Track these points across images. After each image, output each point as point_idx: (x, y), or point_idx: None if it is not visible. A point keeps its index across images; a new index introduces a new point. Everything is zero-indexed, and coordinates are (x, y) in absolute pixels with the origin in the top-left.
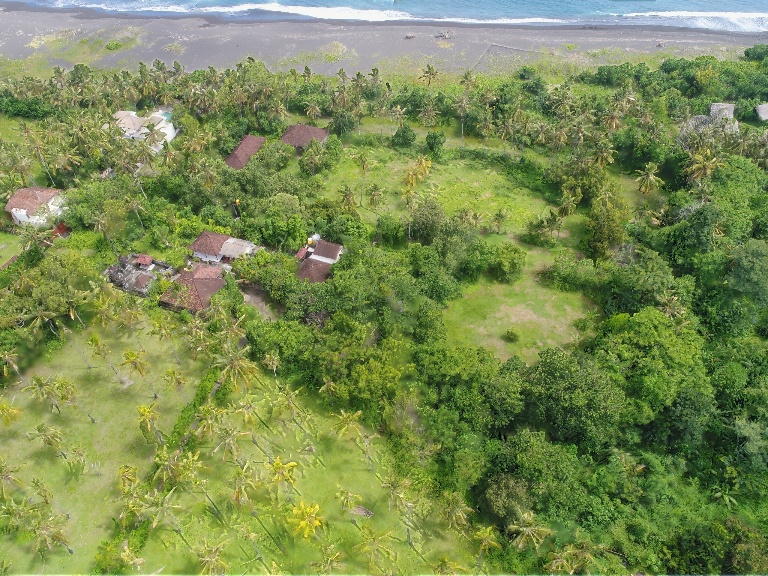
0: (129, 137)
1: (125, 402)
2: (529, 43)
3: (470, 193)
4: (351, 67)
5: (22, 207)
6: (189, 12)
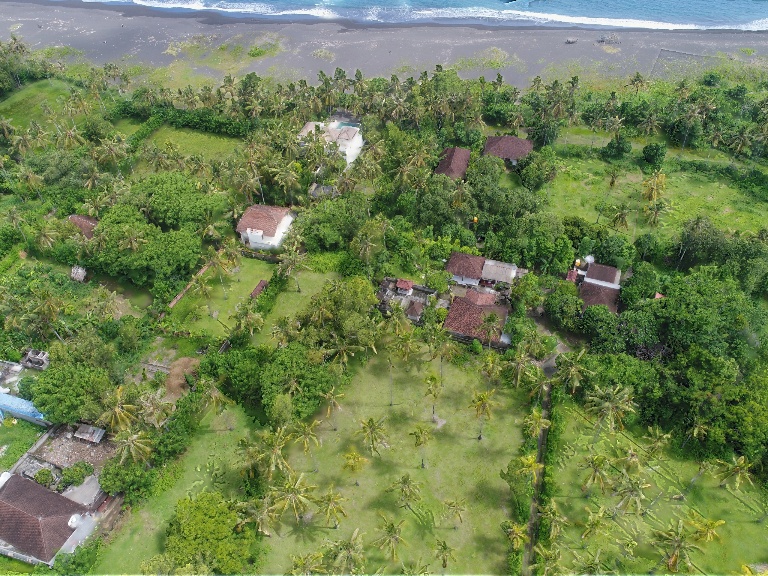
0: (328, 150)
1: (447, 444)
2: (701, 48)
3: (709, 208)
4: (520, 74)
5: (257, 227)
6: (321, 16)
